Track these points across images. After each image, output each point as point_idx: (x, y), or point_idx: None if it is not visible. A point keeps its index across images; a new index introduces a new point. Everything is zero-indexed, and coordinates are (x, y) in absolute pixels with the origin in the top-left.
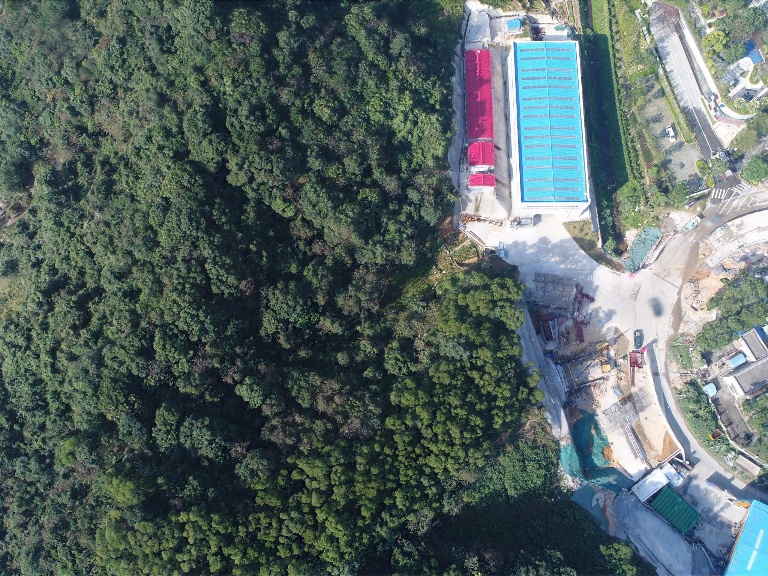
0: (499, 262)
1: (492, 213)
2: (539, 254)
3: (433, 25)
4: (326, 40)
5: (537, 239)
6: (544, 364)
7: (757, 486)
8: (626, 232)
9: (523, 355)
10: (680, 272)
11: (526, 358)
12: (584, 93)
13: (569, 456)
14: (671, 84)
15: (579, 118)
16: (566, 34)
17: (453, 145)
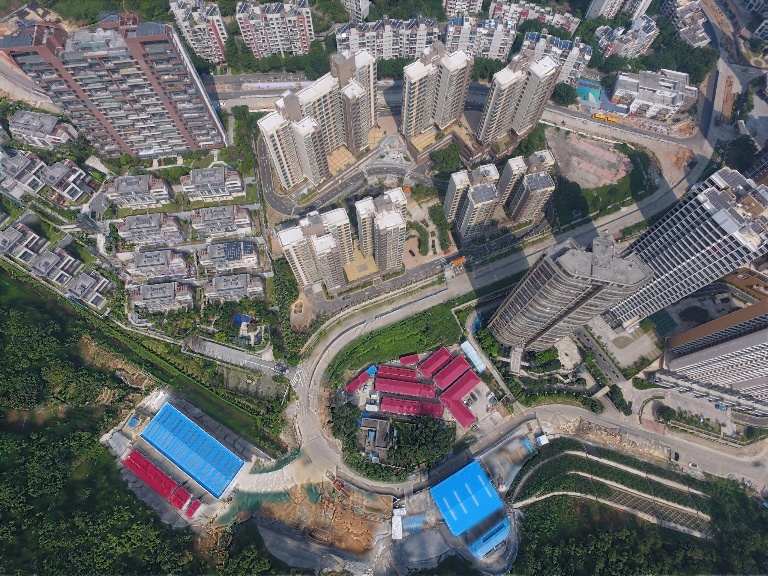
0: (241, 526)
1: (215, 510)
2: (254, 499)
3: (95, 471)
4: (37, 573)
5: (246, 494)
6: (304, 547)
7: (431, 470)
8: (279, 437)
9: (289, 561)
10: (315, 429)
11: (292, 559)
12: (199, 407)
13: (355, 568)
14: (228, 362)
15: (203, 433)
16: (163, 394)
17: (162, 514)
